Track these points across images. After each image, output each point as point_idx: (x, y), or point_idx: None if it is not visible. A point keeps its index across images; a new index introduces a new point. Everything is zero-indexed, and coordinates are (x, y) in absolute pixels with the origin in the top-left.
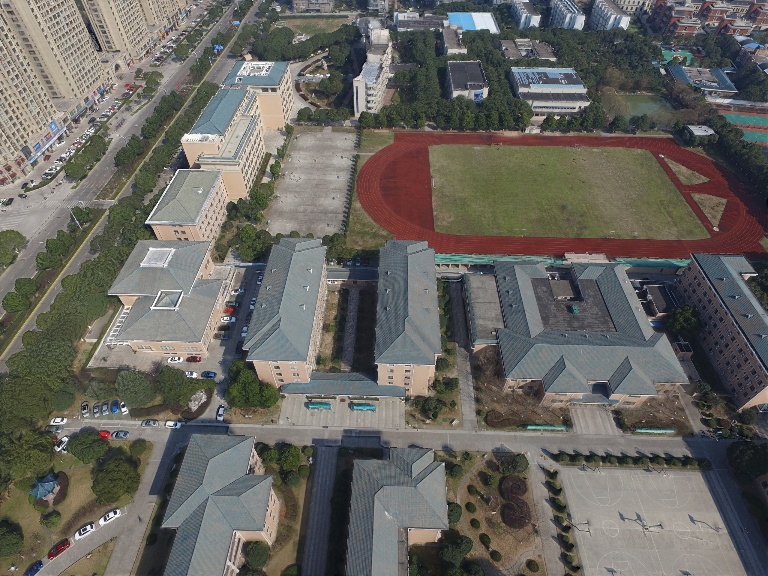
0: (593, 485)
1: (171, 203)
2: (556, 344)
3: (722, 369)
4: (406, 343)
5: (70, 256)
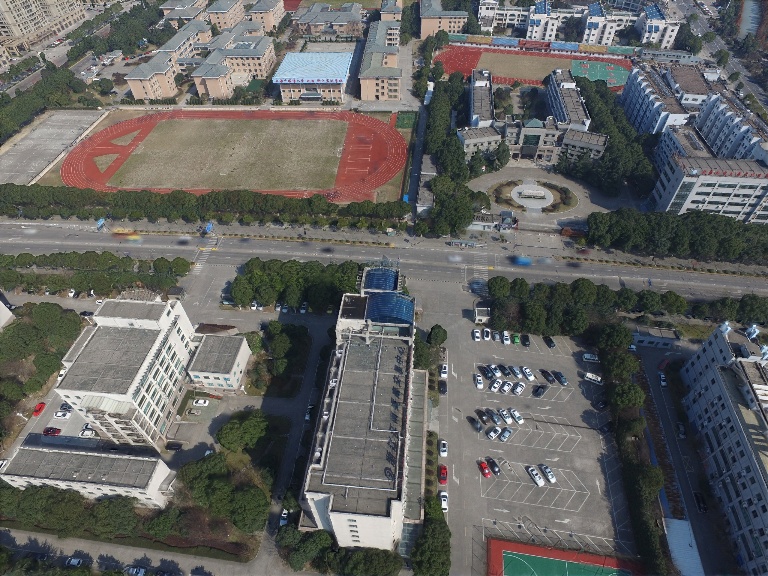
0: None
1: None
2: (316, 12)
3: None
4: (260, 5)
5: None
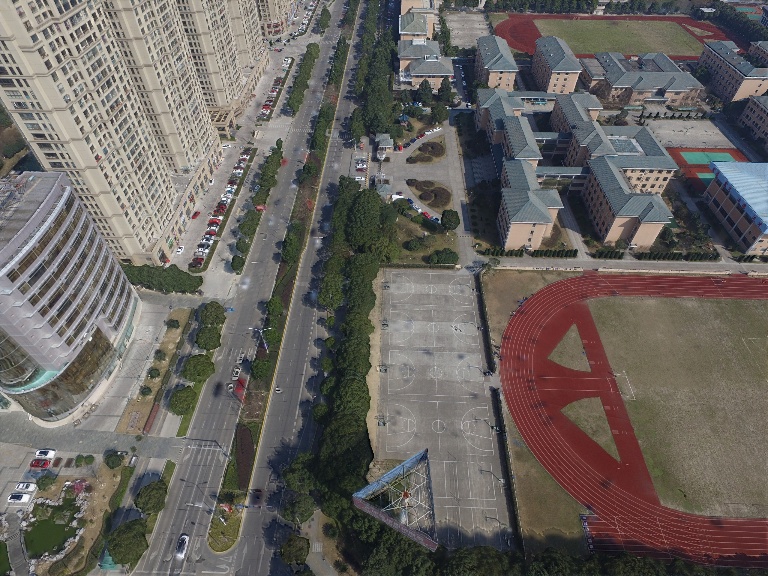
0: (659, 124)
1: (412, 23)
2: None
3: (721, 92)
4: (566, 62)
5: (345, 60)
